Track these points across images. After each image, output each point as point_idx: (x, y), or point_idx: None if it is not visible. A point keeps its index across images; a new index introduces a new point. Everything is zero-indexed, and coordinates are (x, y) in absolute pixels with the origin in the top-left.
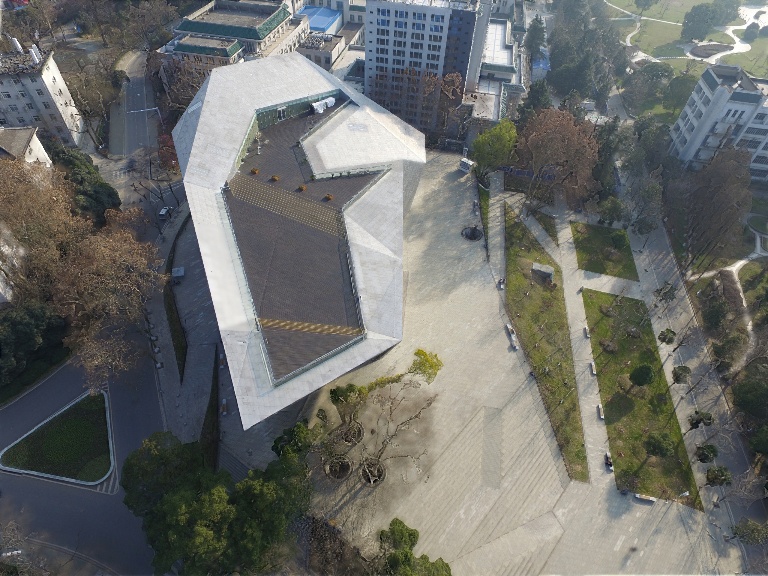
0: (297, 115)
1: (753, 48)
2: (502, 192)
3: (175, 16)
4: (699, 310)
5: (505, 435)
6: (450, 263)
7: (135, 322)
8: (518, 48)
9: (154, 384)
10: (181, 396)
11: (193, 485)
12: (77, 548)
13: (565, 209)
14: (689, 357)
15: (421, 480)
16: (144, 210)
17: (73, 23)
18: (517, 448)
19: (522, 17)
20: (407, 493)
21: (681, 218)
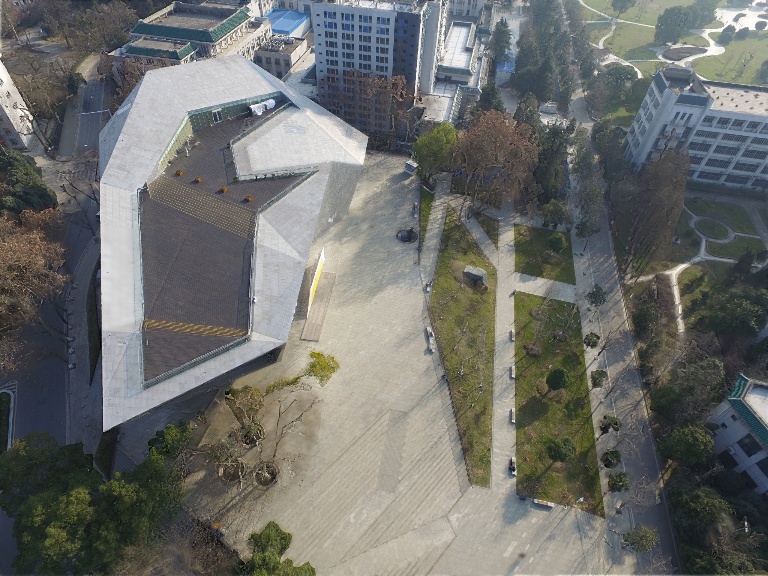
0: (235, 117)
1: (727, 51)
2: (447, 194)
3: (134, 19)
4: (632, 314)
5: (408, 439)
6: (380, 265)
7: (30, 323)
8: (484, 51)
9: (63, 385)
10: (88, 397)
11: (63, 486)
12: None
13: (511, 212)
14: (615, 361)
15: (314, 483)
16: (83, 211)
17: (39, 26)
18: (418, 452)
19: (490, 20)
20: (297, 496)
21: (628, 221)
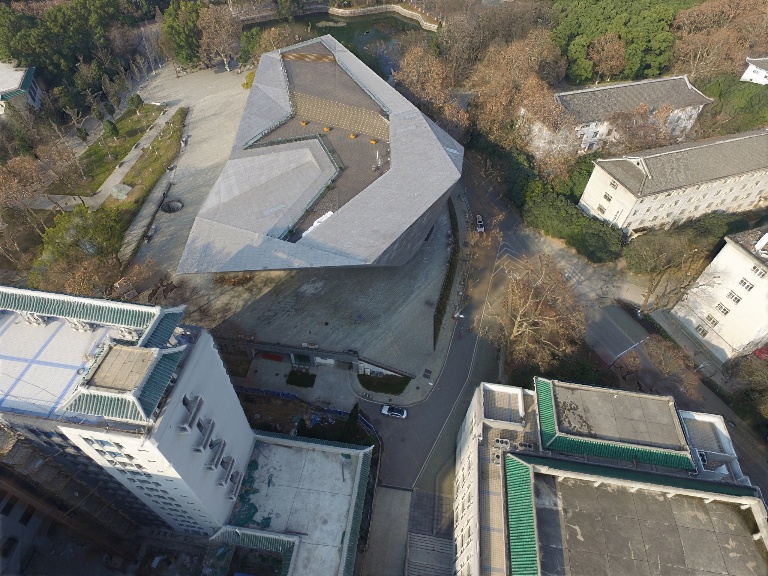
0: None
1: None
2: None
3: None
4: None
5: None
6: (207, 182)
7: None
8: None
9: None
10: None
11: None
12: (404, 92)
13: None
14: None
15: None
16: (504, 229)
17: None
18: (211, 108)
19: None
20: None
21: None
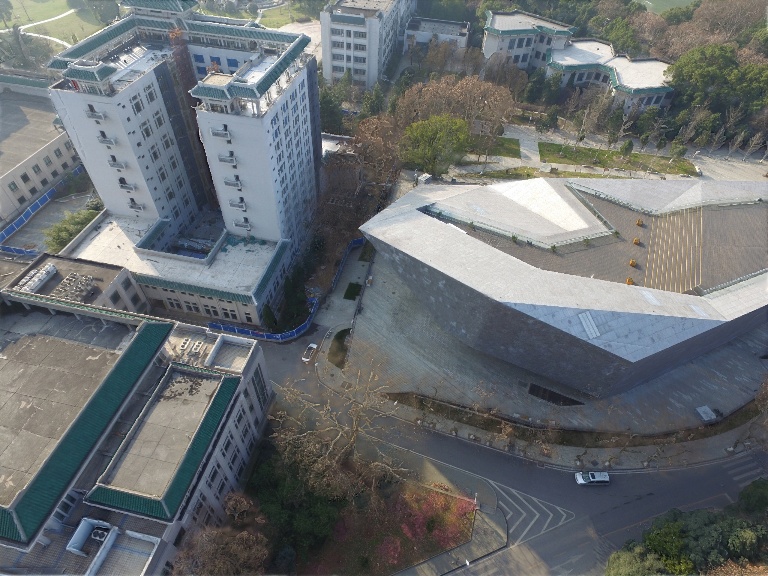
0: None
1: None
2: None
3: None
4: None
5: None
6: None
7: None
8: None
9: None
10: None
11: None
12: None
13: None
14: None
15: None
16: (596, 521)
17: None
18: None
19: None
20: None
21: None
